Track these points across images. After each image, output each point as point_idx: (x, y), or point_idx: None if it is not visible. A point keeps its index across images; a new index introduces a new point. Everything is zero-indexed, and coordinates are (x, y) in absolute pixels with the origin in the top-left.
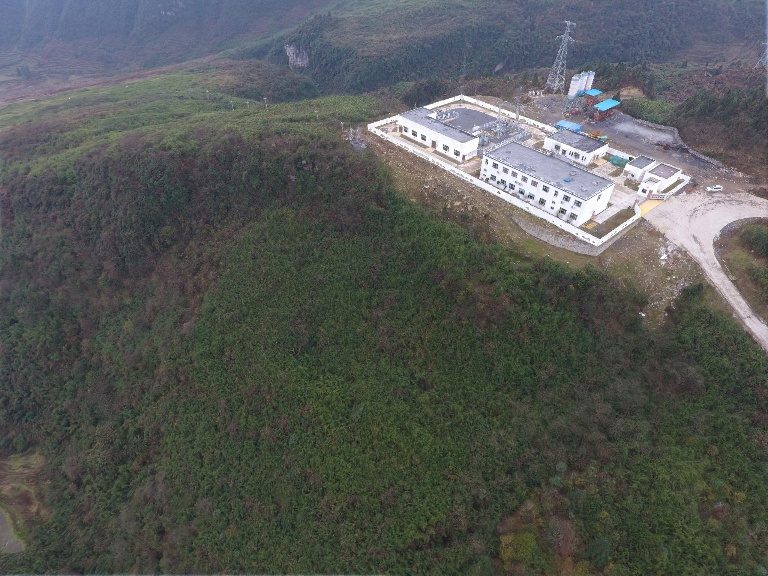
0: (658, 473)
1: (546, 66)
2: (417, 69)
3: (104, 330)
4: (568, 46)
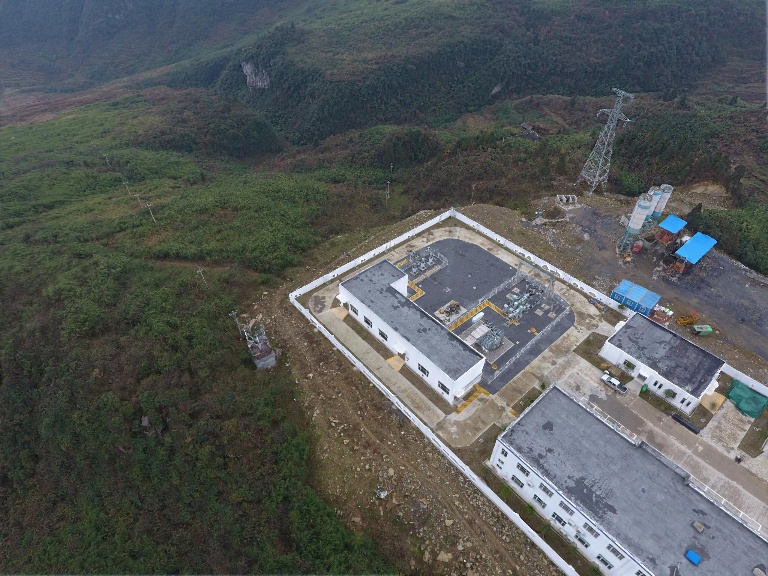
0: None
1: (553, 88)
2: (398, 95)
3: None
4: (579, 65)
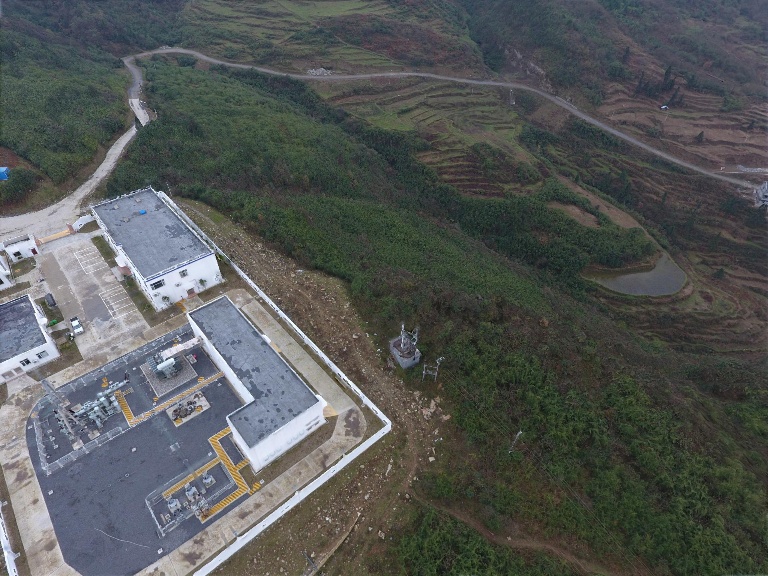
0: None
1: None
2: None
3: None
4: None
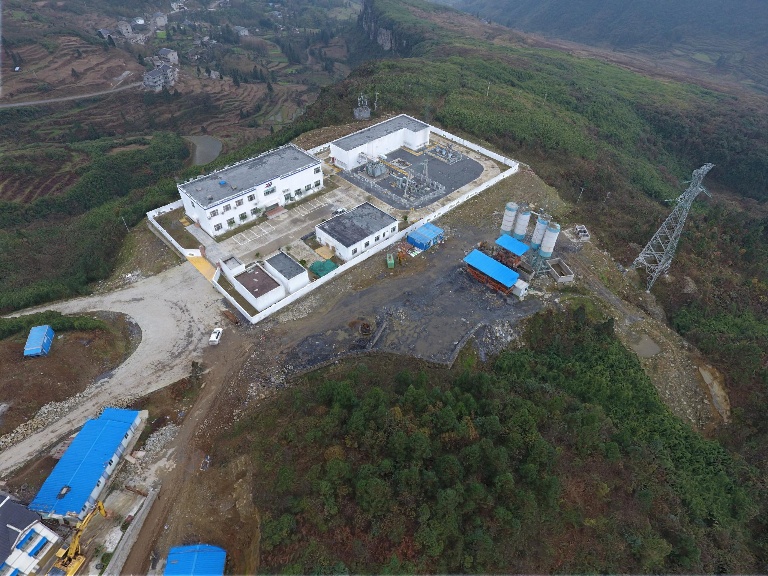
0: None
1: None
2: None
3: None
4: None
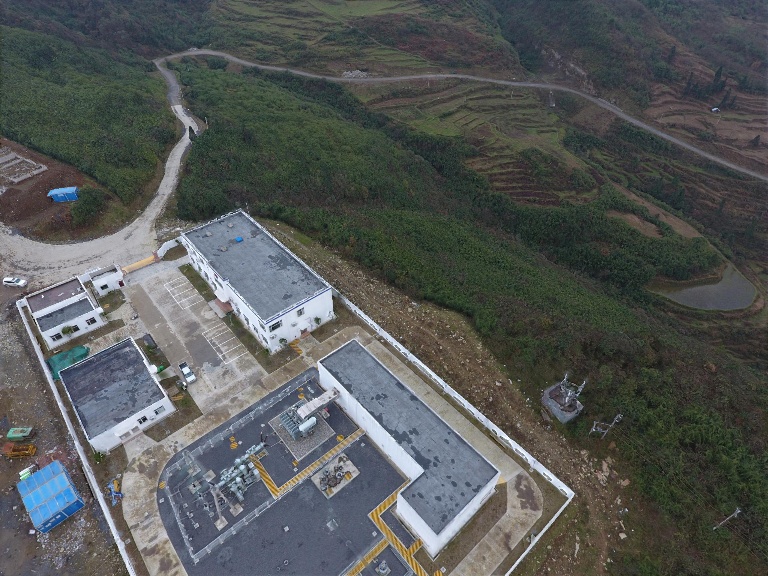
0: (285, 177)
1: None
2: None
3: (760, 377)
4: None
